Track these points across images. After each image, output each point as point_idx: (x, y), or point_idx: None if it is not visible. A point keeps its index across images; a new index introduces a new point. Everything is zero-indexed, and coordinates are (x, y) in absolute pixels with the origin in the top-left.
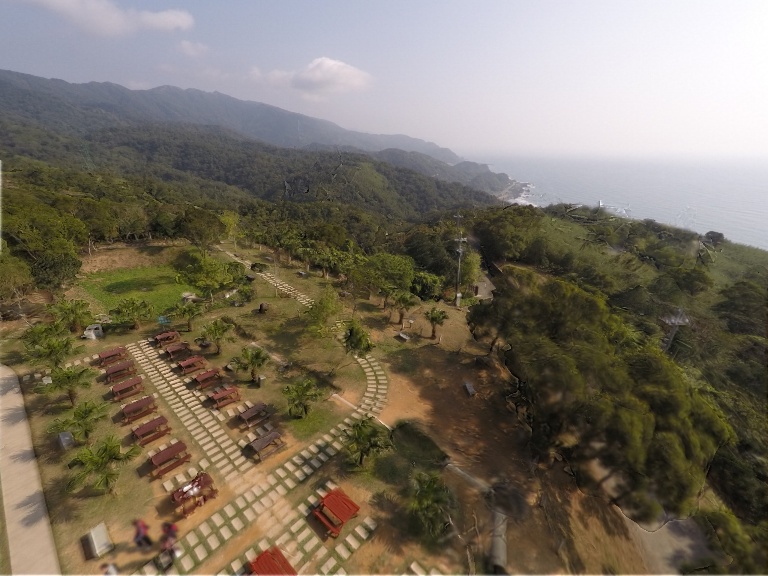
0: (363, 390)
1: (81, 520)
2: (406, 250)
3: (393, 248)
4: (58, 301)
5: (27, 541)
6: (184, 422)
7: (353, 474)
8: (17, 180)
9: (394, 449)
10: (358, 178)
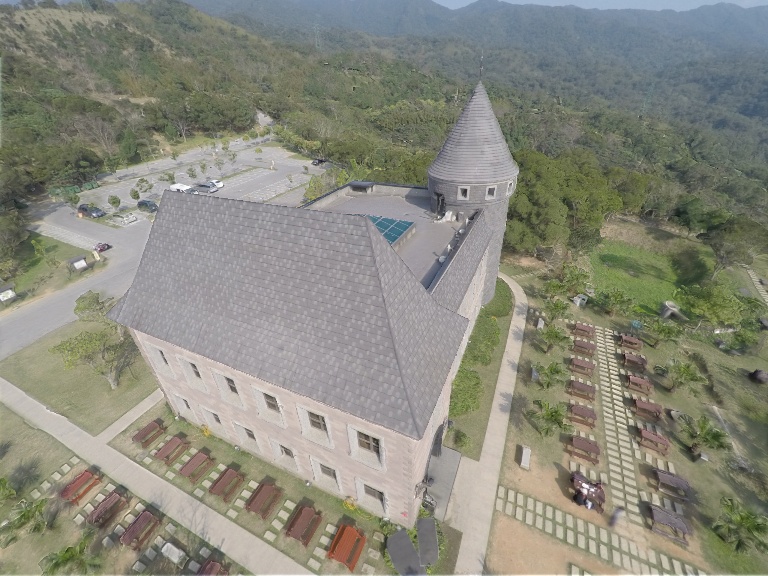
0: None
1: (521, 434)
2: None
3: None
4: (573, 266)
5: (497, 419)
6: (606, 429)
7: None
8: (583, 120)
9: None
10: None
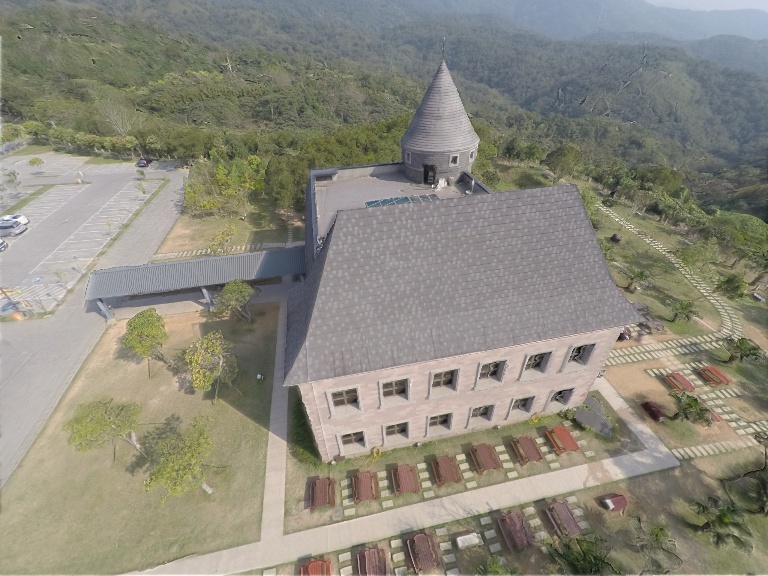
0: (720, 322)
1: None
2: (747, 208)
3: (721, 200)
4: None
5: None
6: None
7: (720, 365)
8: (357, 83)
9: (766, 363)
10: (660, 88)
